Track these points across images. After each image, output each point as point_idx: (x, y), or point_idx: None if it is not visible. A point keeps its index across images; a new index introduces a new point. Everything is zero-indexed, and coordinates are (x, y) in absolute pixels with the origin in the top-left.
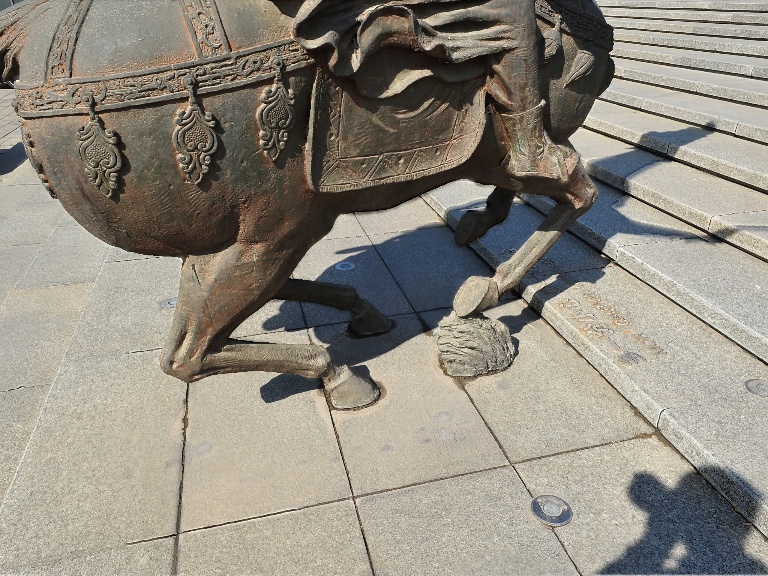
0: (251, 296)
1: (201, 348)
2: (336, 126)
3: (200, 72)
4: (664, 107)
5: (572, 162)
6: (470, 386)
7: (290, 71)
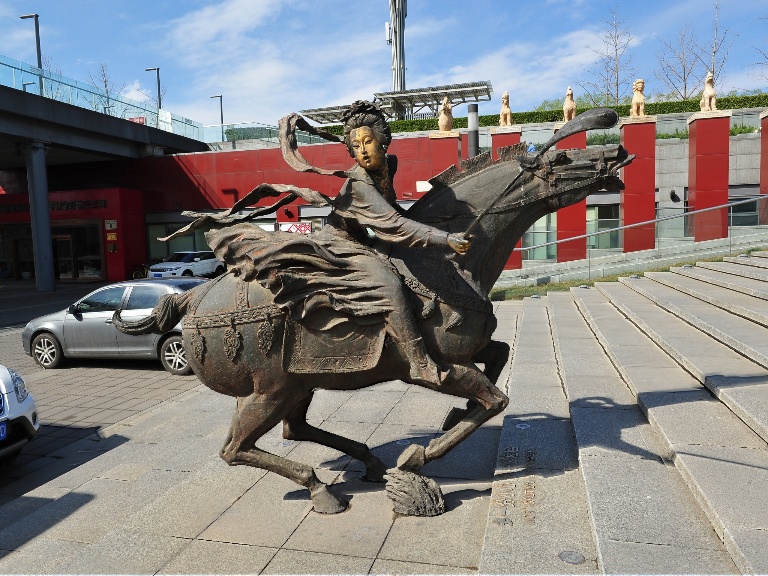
0: (259, 422)
1: (237, 446)
2: (299, 342)
3: (236, 315)
4: (757, 355)
5: (444, 374)
6: (400, 519)
7: (272, 317)
